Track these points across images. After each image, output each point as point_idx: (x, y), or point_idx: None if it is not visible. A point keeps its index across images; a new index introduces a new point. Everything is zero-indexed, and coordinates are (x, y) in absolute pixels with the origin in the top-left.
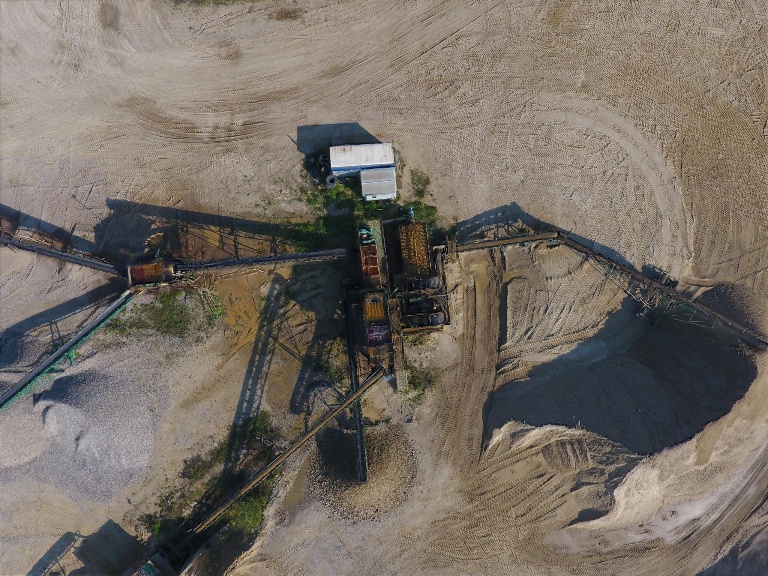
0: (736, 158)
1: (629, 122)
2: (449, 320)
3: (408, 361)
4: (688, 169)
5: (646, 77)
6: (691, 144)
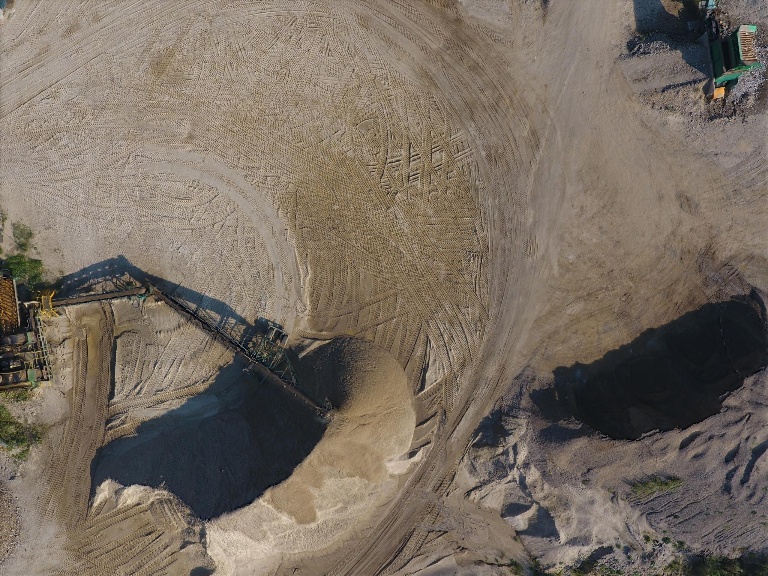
0: (352, 209)
1: (238, 173)
2: (43, 377)
3: (12, 417)
4: (302, 220)
5: (256, 127)
6: (305, 195)
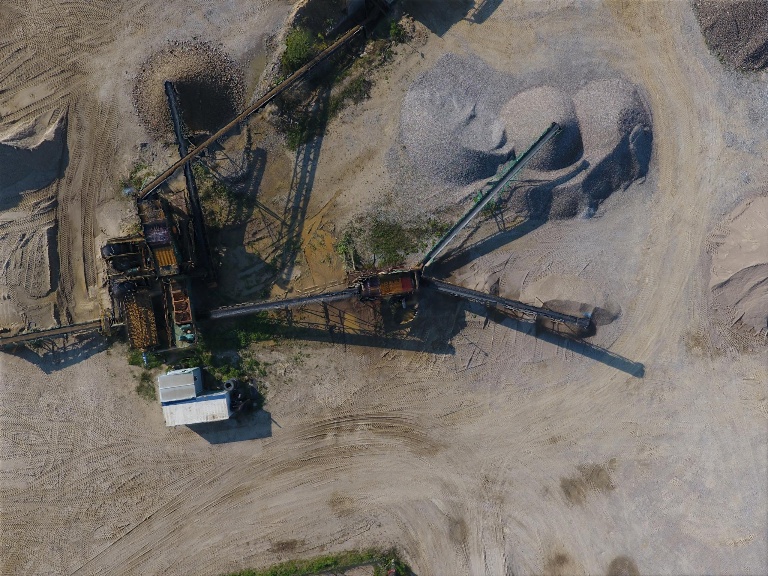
0: None
1: None
2: None
3: None
4: None
5: None
6: None
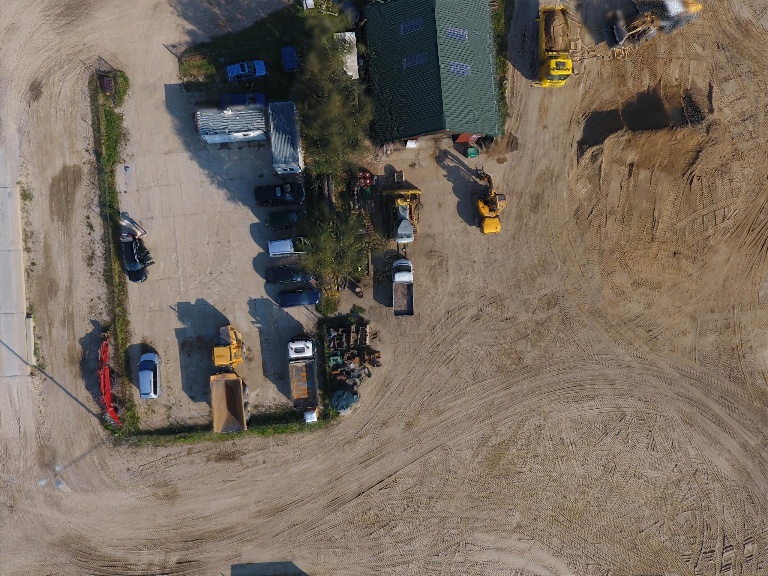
0: None
1: (562, 562)
2: None
3: None
4: None
5: (581, 517)
6: None
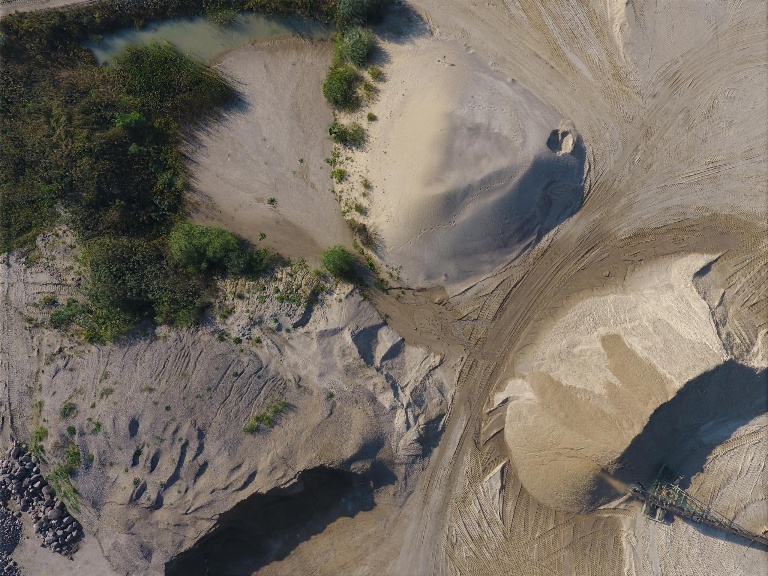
0: None
1: None
2: None
3: None
4: None
5: None
6: None
